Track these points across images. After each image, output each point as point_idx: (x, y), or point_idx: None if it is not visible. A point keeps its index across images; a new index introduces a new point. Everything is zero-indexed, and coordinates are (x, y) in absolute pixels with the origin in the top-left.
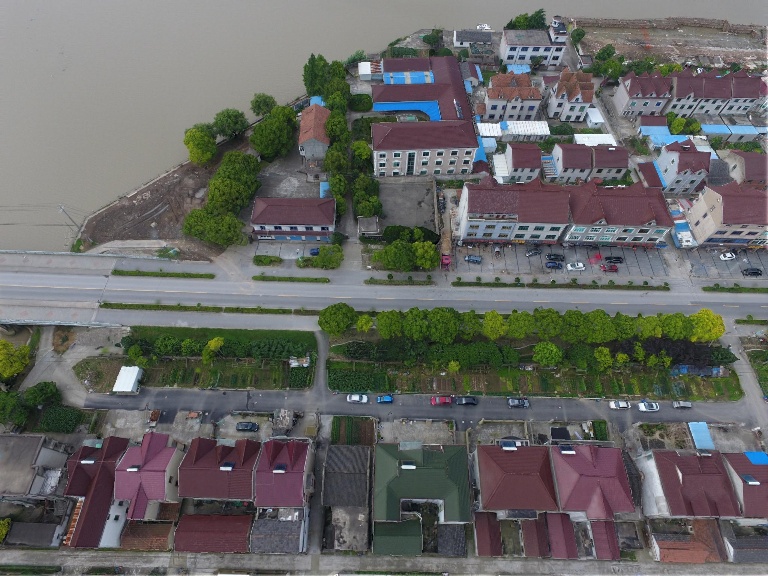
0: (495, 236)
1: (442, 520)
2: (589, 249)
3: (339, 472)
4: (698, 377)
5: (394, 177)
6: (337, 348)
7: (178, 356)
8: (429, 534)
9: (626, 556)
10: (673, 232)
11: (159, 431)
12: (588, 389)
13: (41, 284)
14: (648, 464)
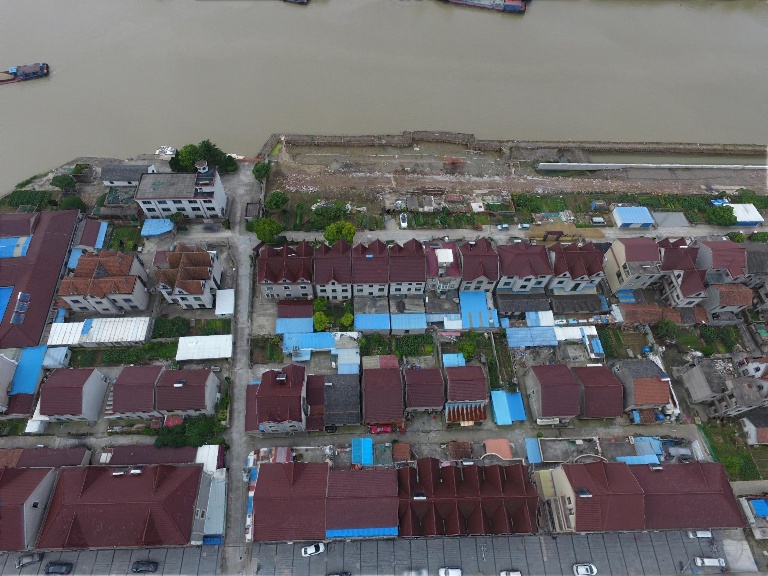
0: None
1: None
2: None
3: None
4: None
5: None
6: None
7: None
8: None
9: None
10: None
11: None
12: None
13: None
14: None
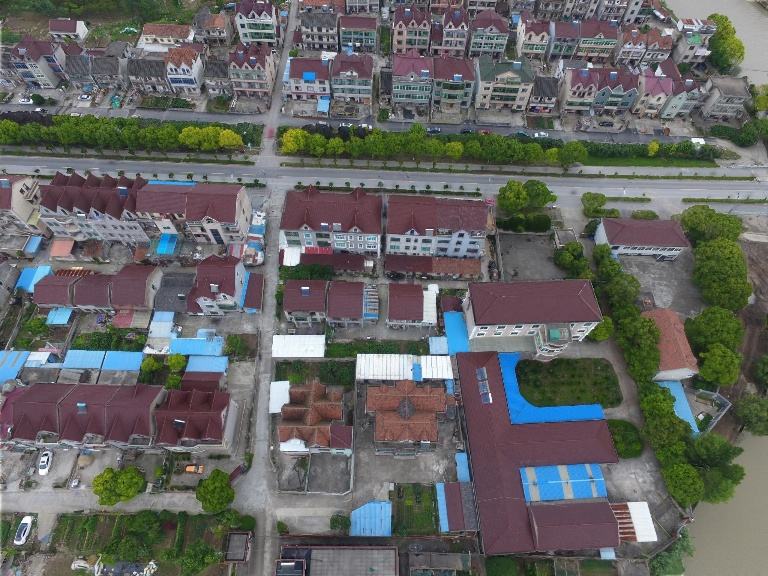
0: None
1: None
2: None
3: (550, 79)
4: None
5: None
6: None
7: None
8: None
9: None
10: None
11: (659, 126)
12: None
13: None
14: None
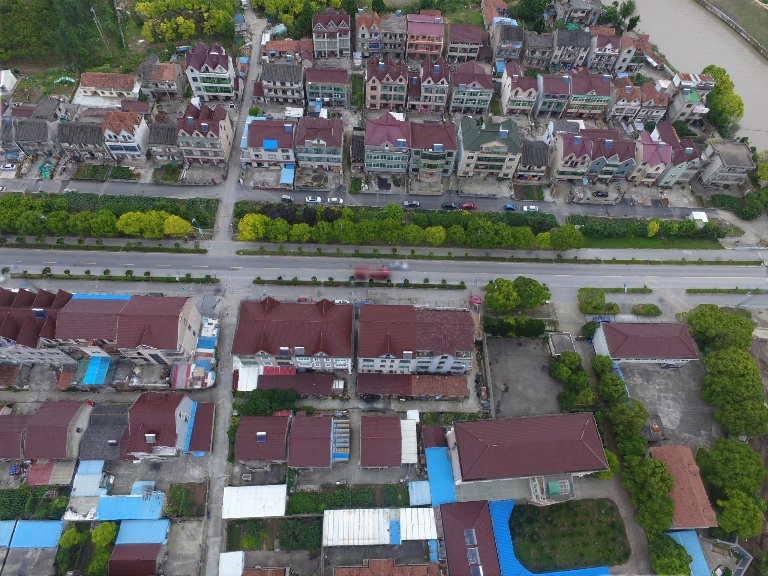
0: None
1: None
2: None
3: (540, 146)
4: None
5: None
6: None
7: None
8: None
9: None
10: None
11: (657, 195)
12: None
13: None
14: None
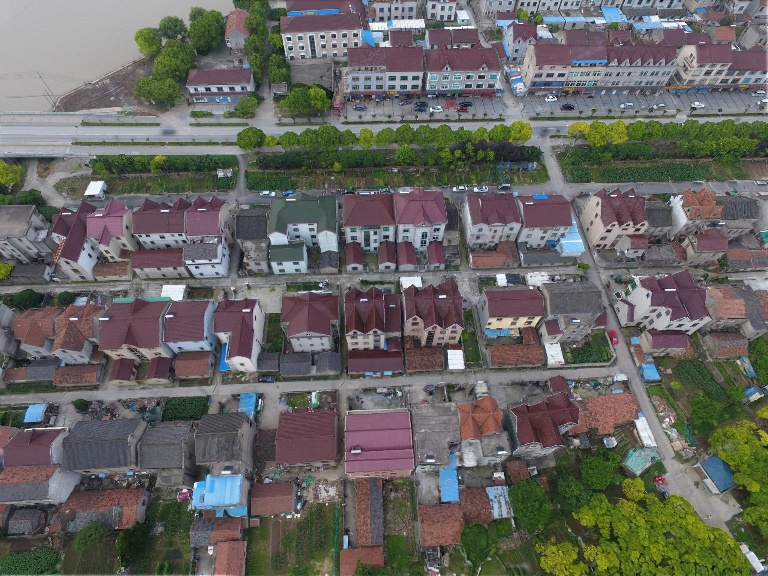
0: (373, 88)
1: (319, 241)
2: (448, 99)
3: (246, 216)
4: (515, 166)
5: (301, 59)
6: (253, 164)
7: (133, 174)
8: (315, 263)
9: (453, 268)
10: (512, 85)
11: None
12: (439, 182)
13: (26, 132)
14: (466, 207)
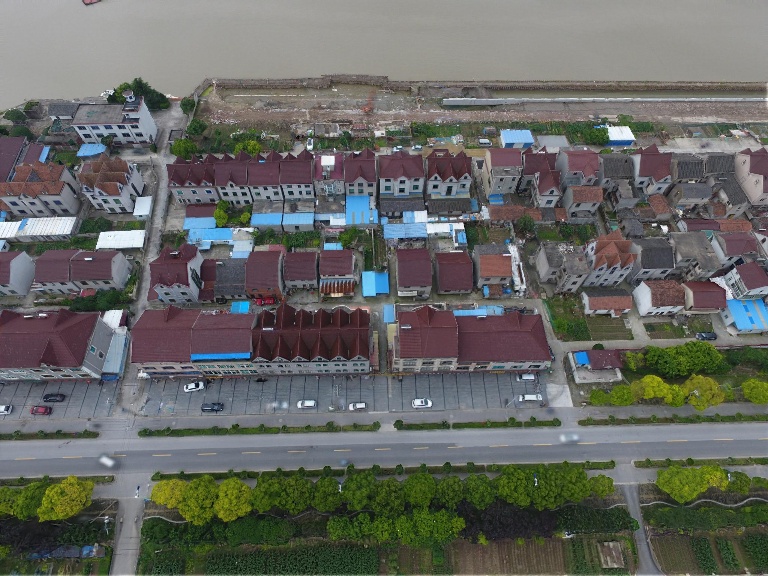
0: None
1: None
2: (35, 384)
3: None
4: (43, 566)
5: None
6: None
7: None
8: None
9: None
10: None
11: None
12: None
13: None
14: None
